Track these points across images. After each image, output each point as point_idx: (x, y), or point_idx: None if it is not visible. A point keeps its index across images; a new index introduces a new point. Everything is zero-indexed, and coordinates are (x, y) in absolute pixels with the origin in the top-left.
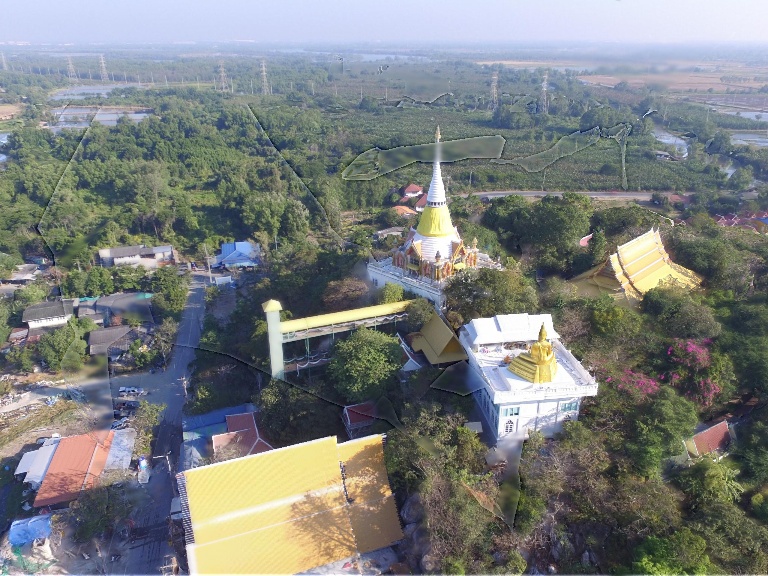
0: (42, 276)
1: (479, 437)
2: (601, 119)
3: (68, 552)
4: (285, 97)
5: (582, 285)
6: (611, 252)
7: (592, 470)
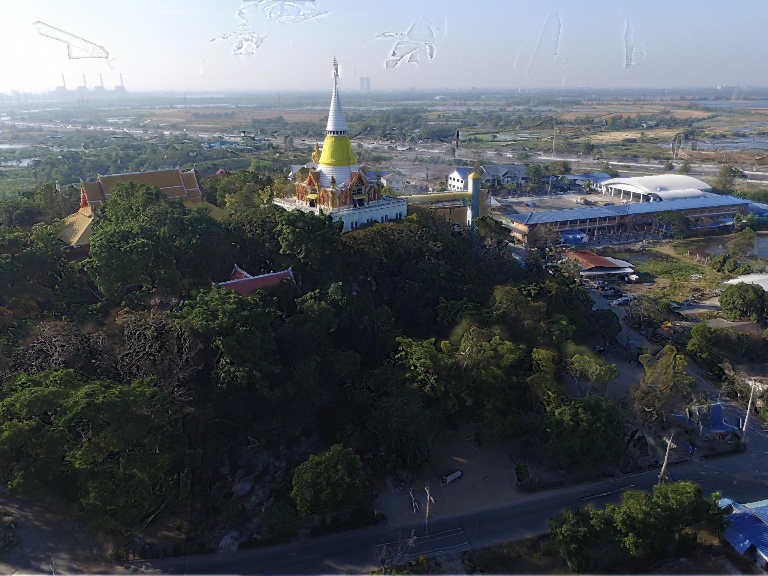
0: None
1: None
2: None
3: None
4: None
5: None
6: None
7: None
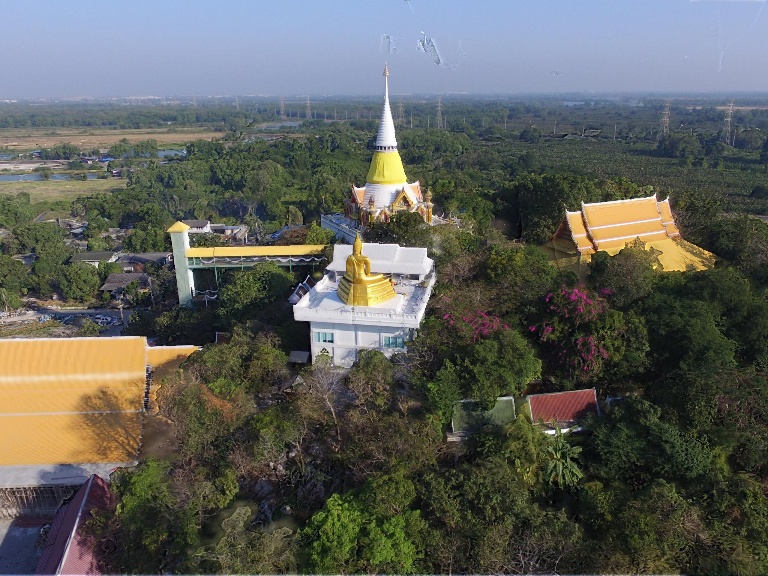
0: (123, 237)
1: None
2: None
3: None
4: (449, 128)
5: (540, 249)
6: None
7: (359, 401)
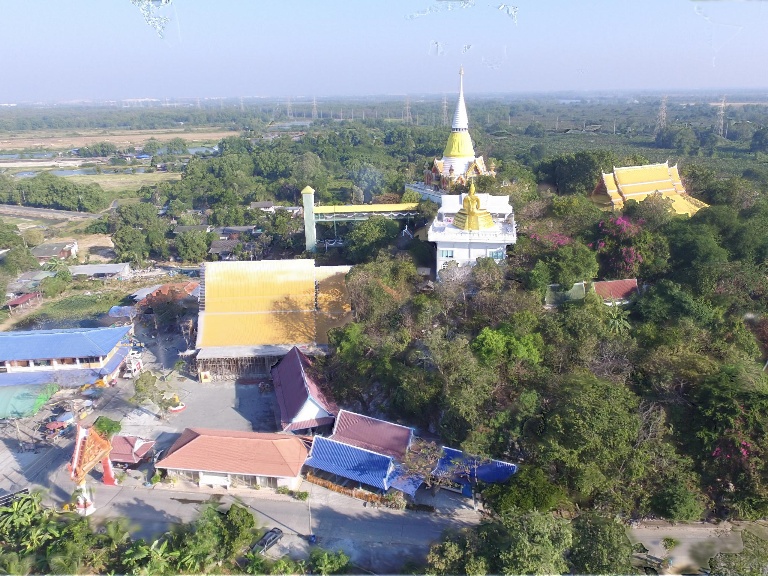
0: (201, 217)
1: (152, 2)
2: None
3: (144, 334)
4: None
5: None
6: None
7: (484, 285)
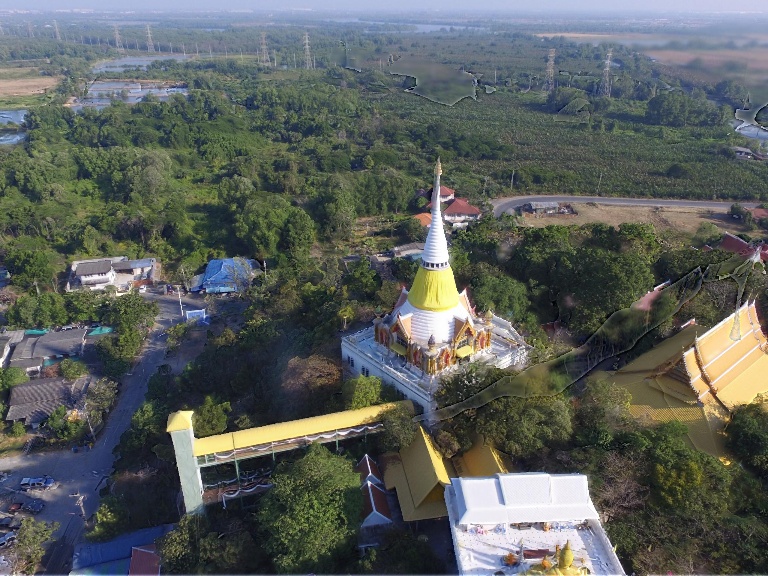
0: None
1: None
2: (671, 106)
3: None
4: (325, 73)
5: (639, 387)
6: (681, 316)
7: None
